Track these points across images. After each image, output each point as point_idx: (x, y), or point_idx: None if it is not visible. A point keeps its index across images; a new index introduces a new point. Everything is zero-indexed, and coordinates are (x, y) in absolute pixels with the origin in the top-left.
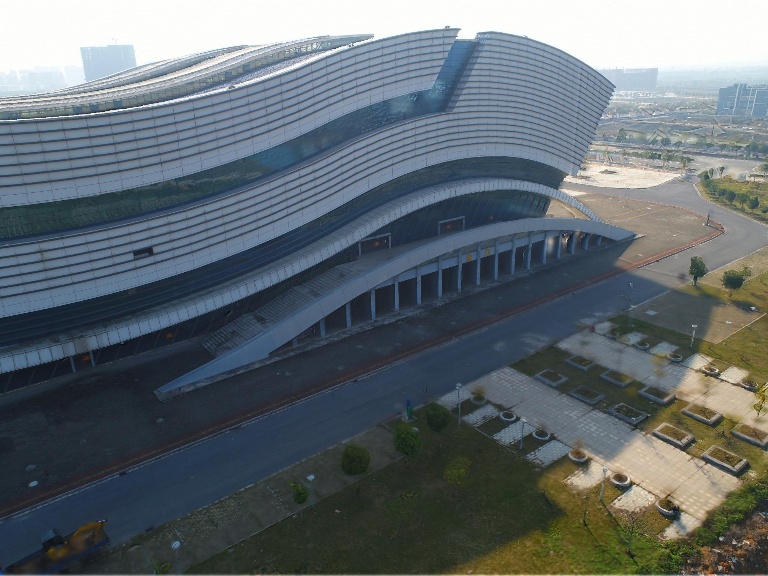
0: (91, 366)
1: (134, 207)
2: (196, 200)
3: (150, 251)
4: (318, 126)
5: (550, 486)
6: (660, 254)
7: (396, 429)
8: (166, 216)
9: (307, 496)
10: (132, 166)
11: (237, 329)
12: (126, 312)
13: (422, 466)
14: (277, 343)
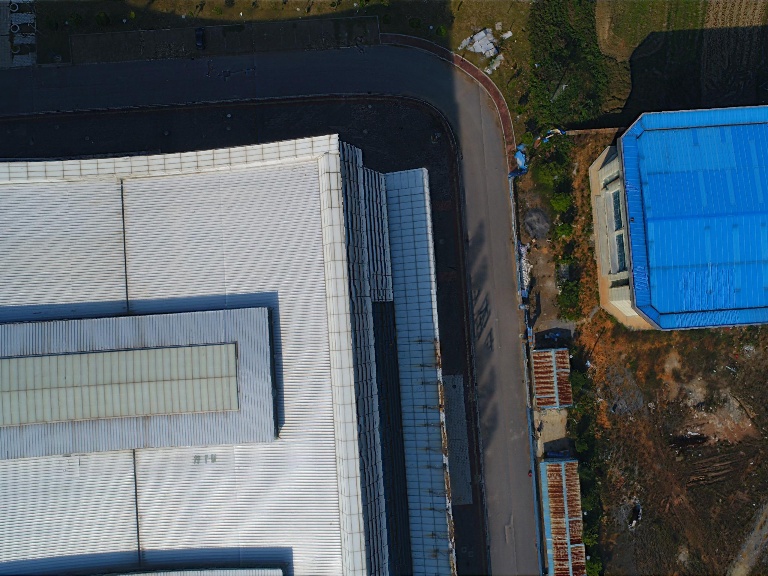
0: None
1: None
2: None
3: None
4: None
5: None
6: None
7: None
8: None
9: None
10: None
11: None
12: None
13: None
14: None
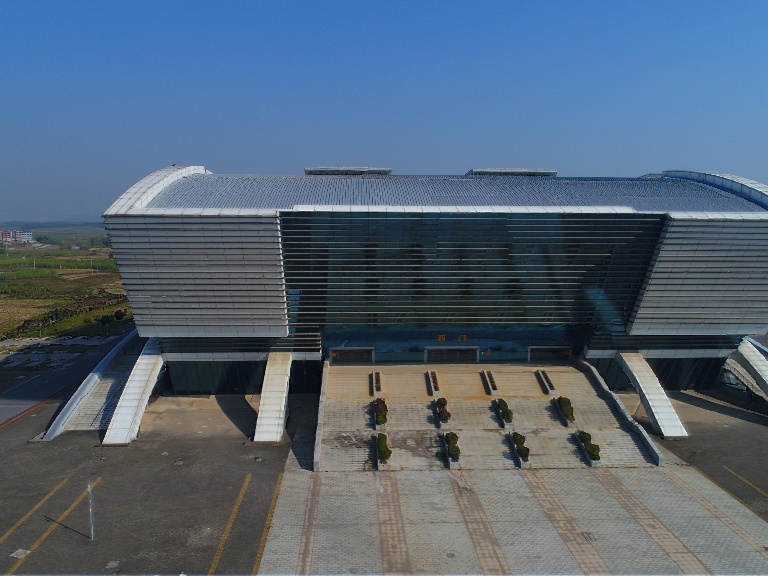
0: None
1: None
2: None
3: None
4: None
5: None
6: (6, 424)
7: None
8: None
9: None
10: None
11: None
12: None
13: None
14: None
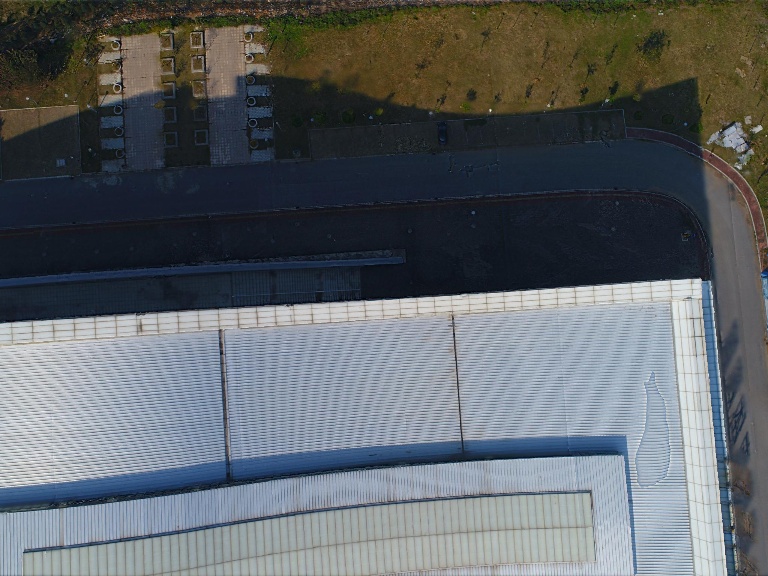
0: None
1: None
2: None
3: None
4: None
5: (277, 75)
6: None
7: None
8: None
9: None
10: None
11: None
12: None
13: None
14: None
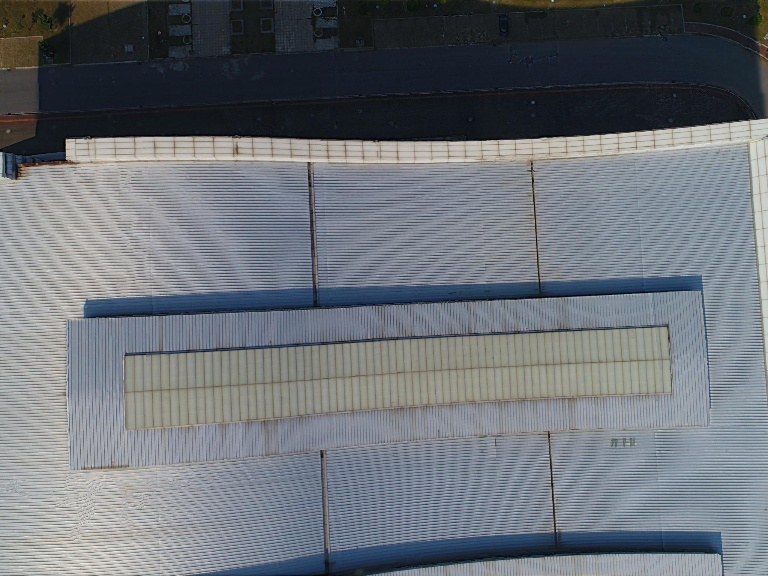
0: None
1: None
2: None
3: None
4: None
5: None
6: None
7: (387, 7)
8: None
9: None
10: None
11: None
12: None
13: None
14: None
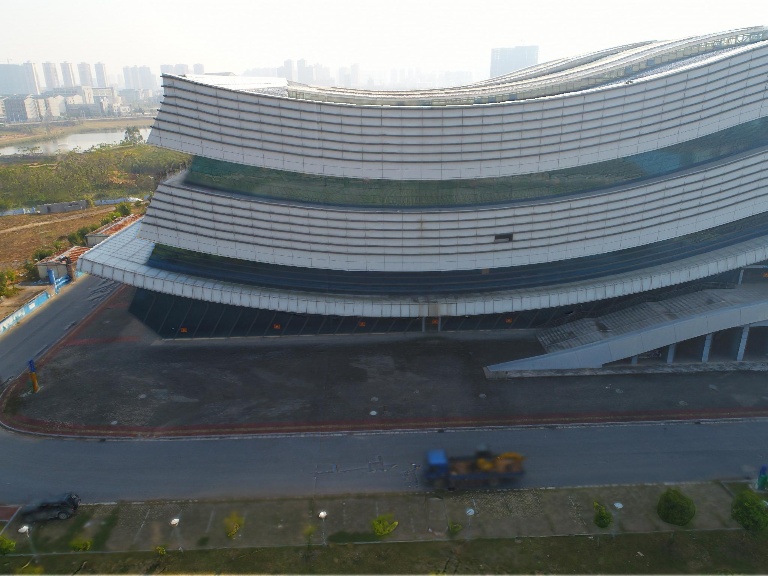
0: (437, 330)
1: (505, 194)
2: (565, 195)
3: (510, 237)
4: (722, 129)
5: None
6: None
7: (738, 493)
8: (532, 206)
9: (609, 523)
10: (512, 155)
11: (575, 331)
12: (476, 289)
13: (764, 550)
14: (614, 356)
